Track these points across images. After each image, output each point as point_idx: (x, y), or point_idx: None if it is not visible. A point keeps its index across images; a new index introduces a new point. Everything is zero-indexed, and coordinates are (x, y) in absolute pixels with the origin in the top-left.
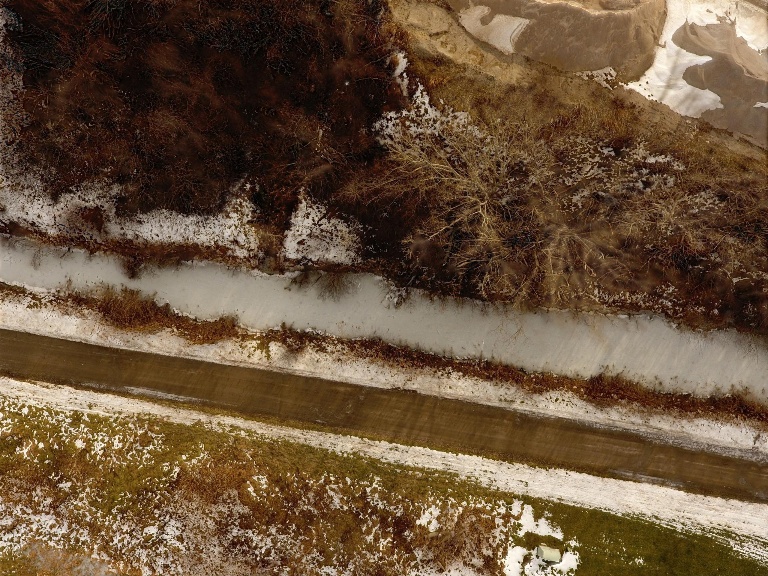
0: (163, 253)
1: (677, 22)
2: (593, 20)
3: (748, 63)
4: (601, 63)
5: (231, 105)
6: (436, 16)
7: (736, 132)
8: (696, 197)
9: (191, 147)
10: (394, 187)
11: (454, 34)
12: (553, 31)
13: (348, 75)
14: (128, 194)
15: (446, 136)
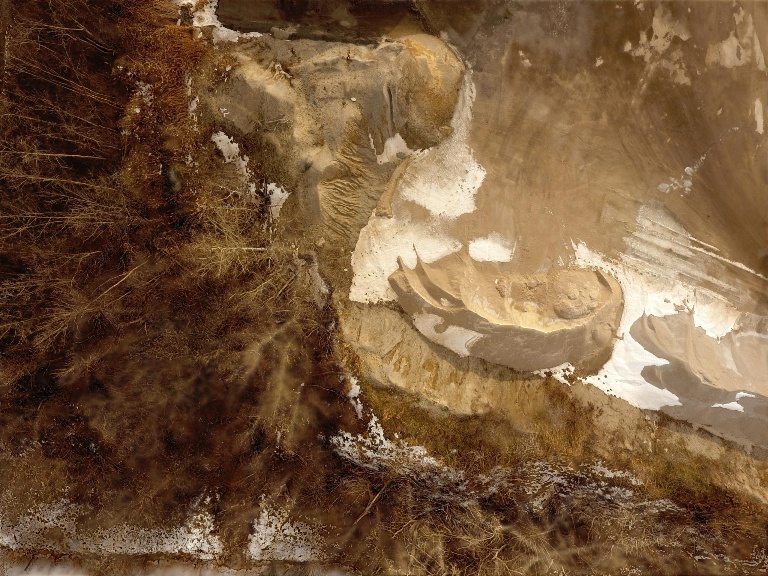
0: (128, 558)
1: (634, 314)
2: (547, 337)
3: (706, 365)
4: (558, 361)
5: (186, 414)
6: (389, 326)
7: (695, 423)
8: (655, 502)
9: (148, 457)
10: (356, 486)
11: (408, 341)
12: (508, 344)
13: (303, 376)
14: (87, 513)
15: (403, 462)
